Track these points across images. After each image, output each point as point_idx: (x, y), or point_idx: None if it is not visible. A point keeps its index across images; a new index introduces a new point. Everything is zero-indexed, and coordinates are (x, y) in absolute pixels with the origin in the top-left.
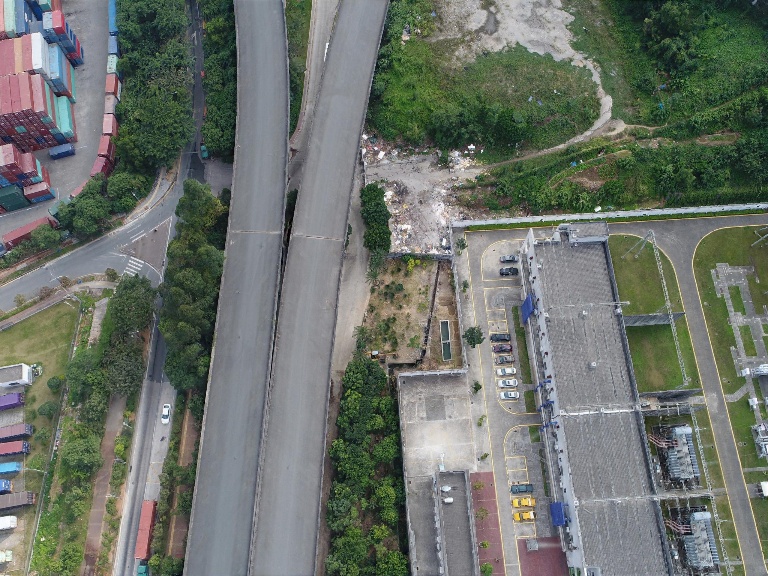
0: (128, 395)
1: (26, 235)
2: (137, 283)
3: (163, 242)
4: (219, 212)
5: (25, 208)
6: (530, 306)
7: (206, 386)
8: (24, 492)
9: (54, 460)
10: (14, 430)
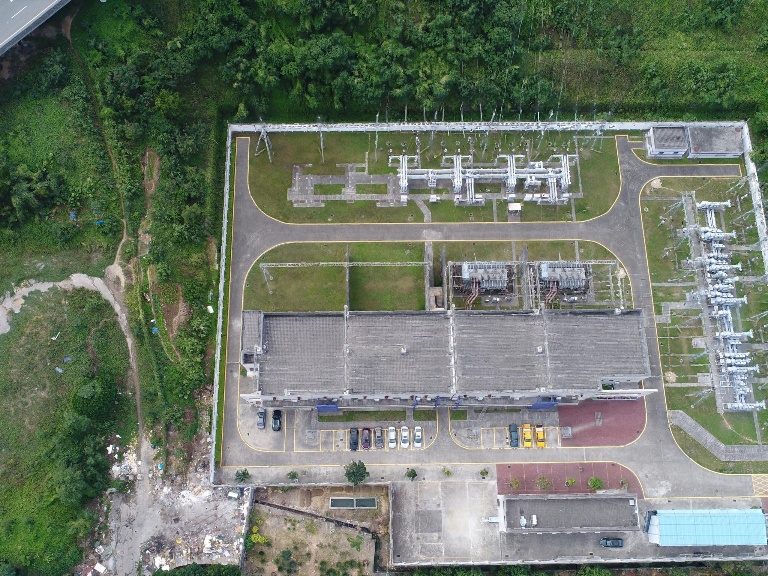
0: None
1: None
2: None
3: None
4: None
5: None
6: None
7: None
8: None
9: None
10: None
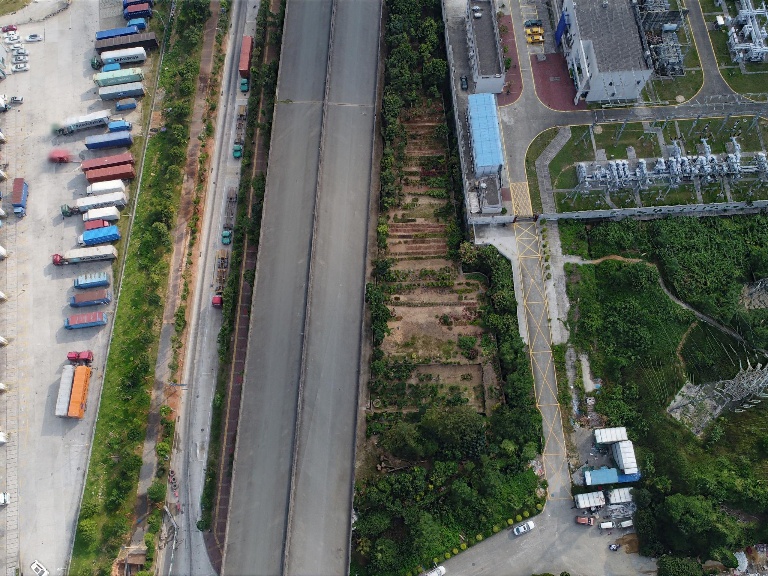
0: None
1: None
2: None
3: None
4: None
5: None
6: None
7: None
8: (152, 32)
9: (171, 22)
10: None
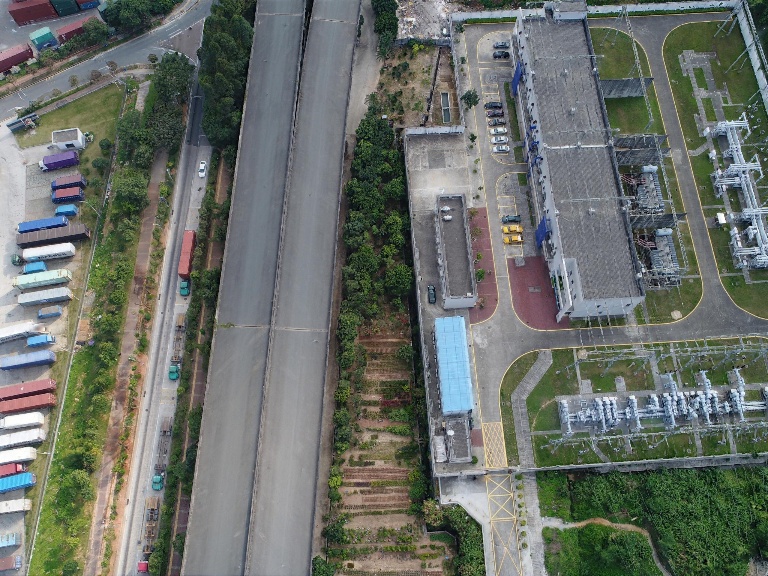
0: (170, 148)
1: (77, 30)
2: (177, 58)
3: (197, 37)
4: (248, 4)
5: (75, 14)
6: (519, 70)
7: (238, 136)
8: (82, 224)
9: (106, 206)
10: (72, 179)
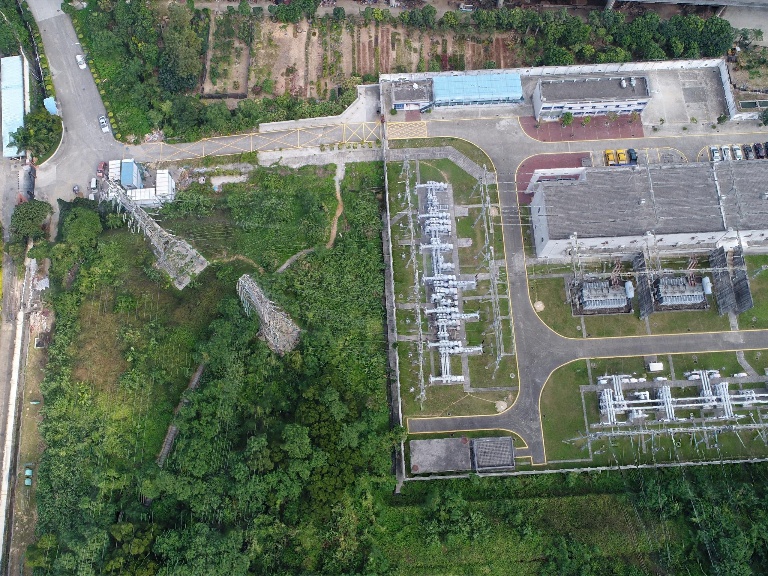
0: None
1: None
2: None
3: None
4: None
5: None
6: None
7: None
8: None
9: None
10: None
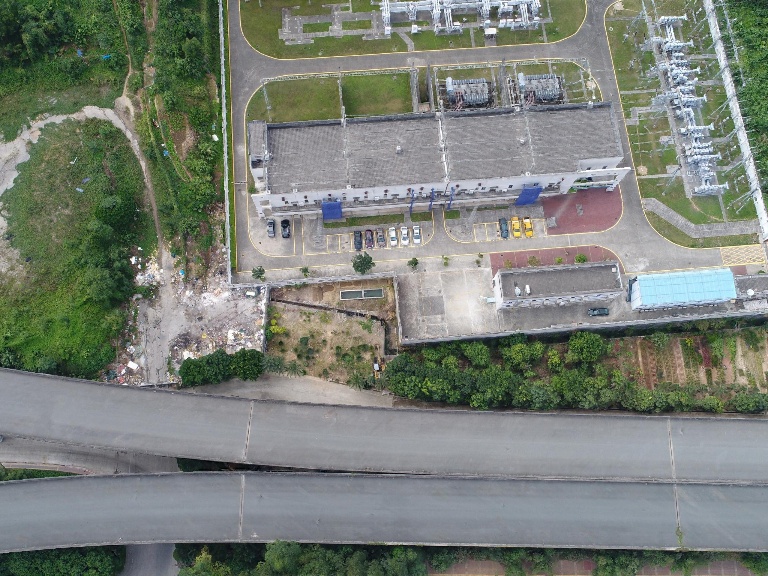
0: None
1: None
2: None
3: None
4: None
5: None
6: (335, 205)
7: None
8: None
9: None
10: None
